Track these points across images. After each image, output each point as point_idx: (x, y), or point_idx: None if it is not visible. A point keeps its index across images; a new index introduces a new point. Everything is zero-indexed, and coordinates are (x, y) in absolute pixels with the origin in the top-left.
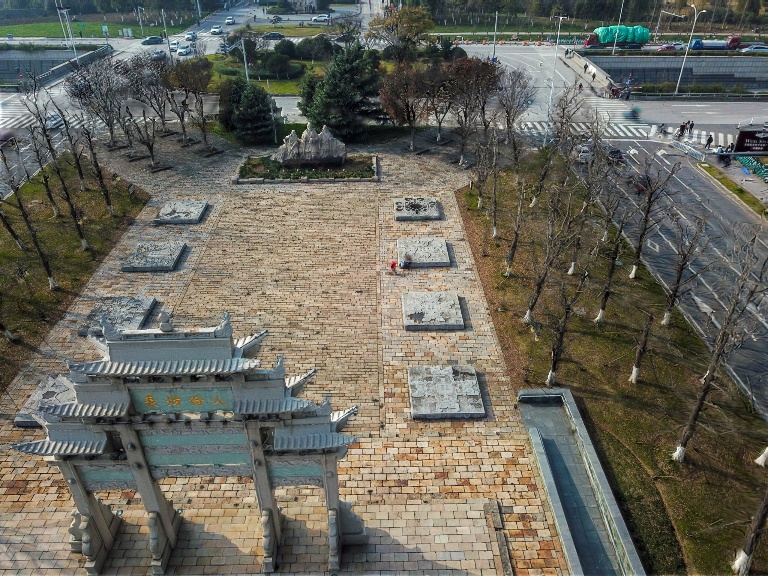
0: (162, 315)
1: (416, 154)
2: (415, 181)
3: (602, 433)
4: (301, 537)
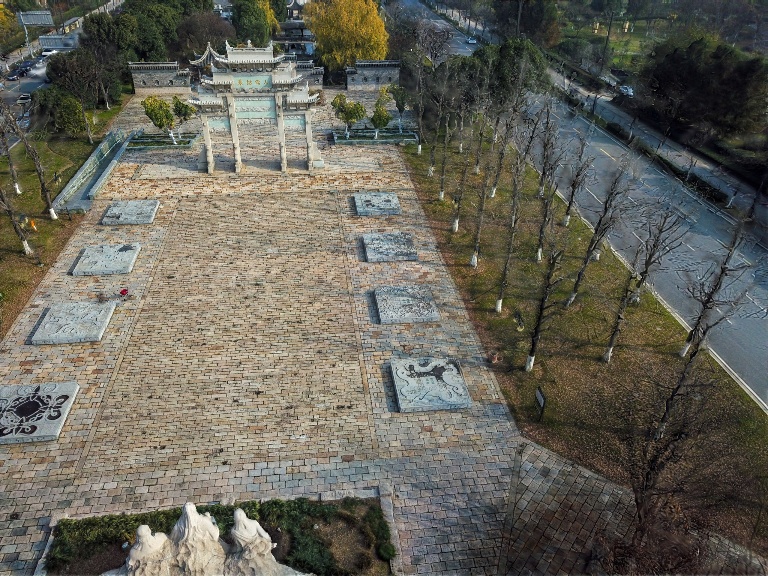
0: None
1: None
2: None
3: None
4: None
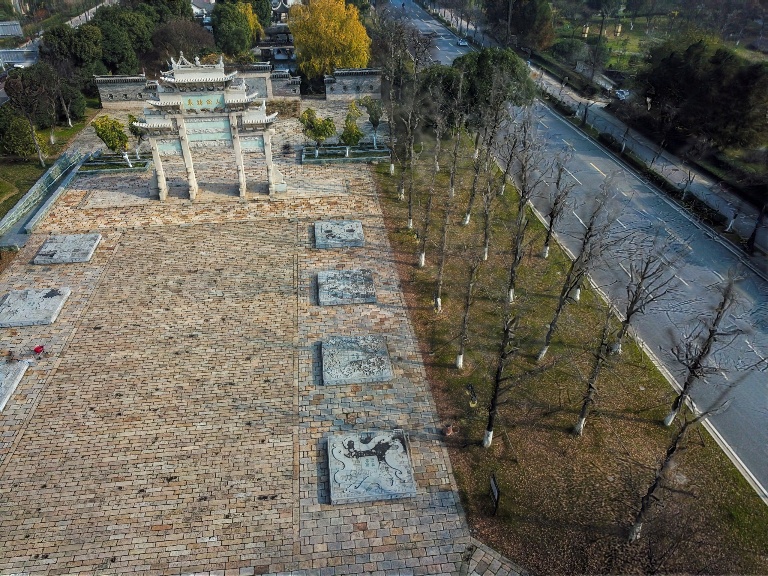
0: None
1: None
2: None
3: None
4: None
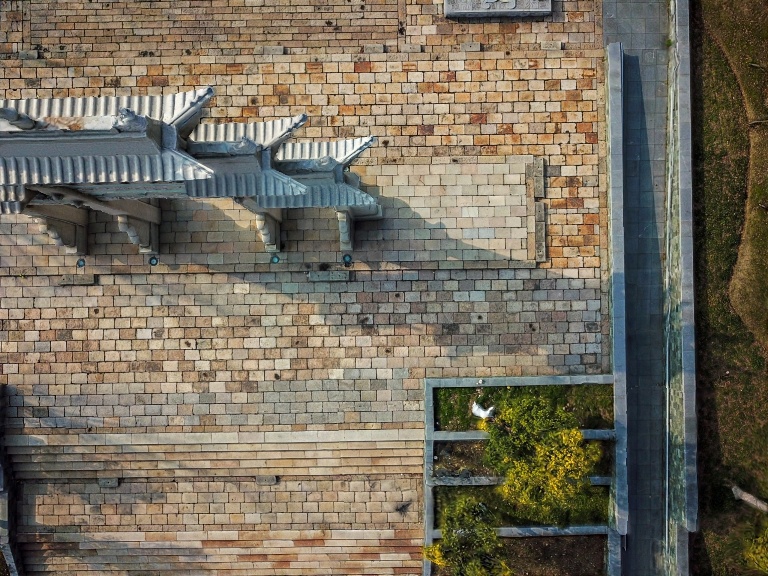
0: (0, 115)
1: None
2: None
3: (709, 47)
4: (305, 208)
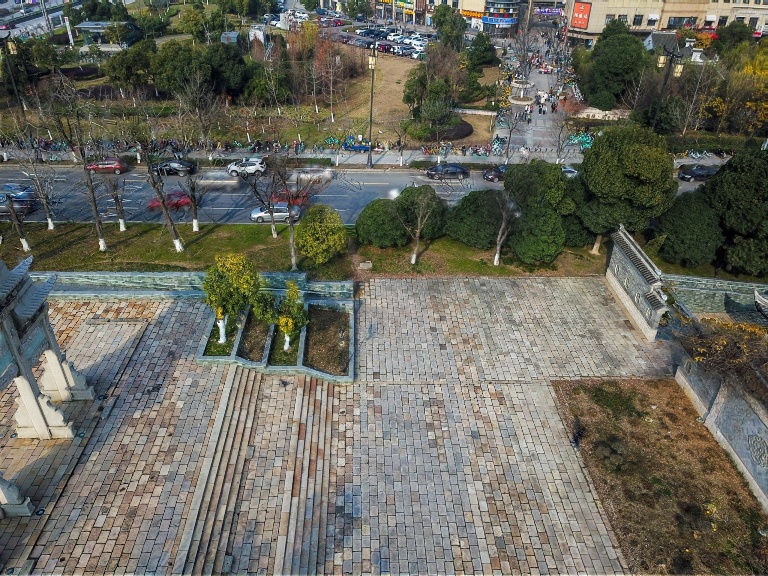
0: None
1: None
2: None
3: None
4: None
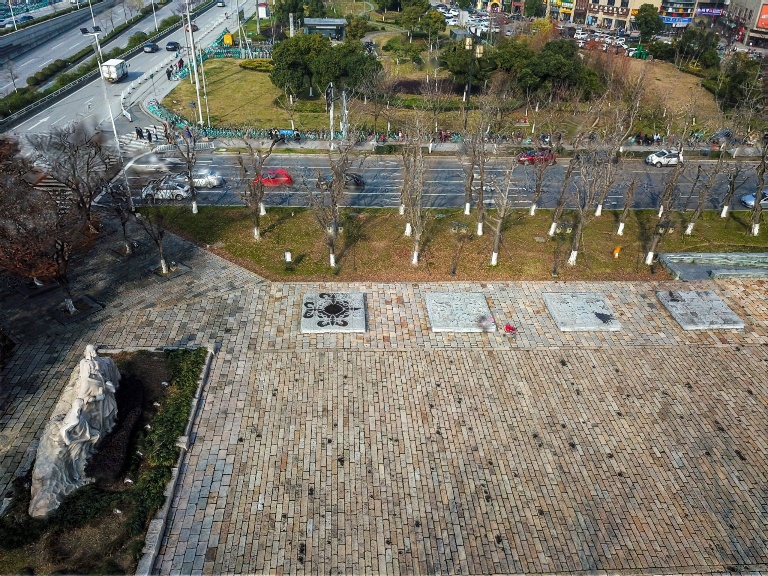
0: None
1: (102, 307)
2: (223, 312)
3: None
4: None
